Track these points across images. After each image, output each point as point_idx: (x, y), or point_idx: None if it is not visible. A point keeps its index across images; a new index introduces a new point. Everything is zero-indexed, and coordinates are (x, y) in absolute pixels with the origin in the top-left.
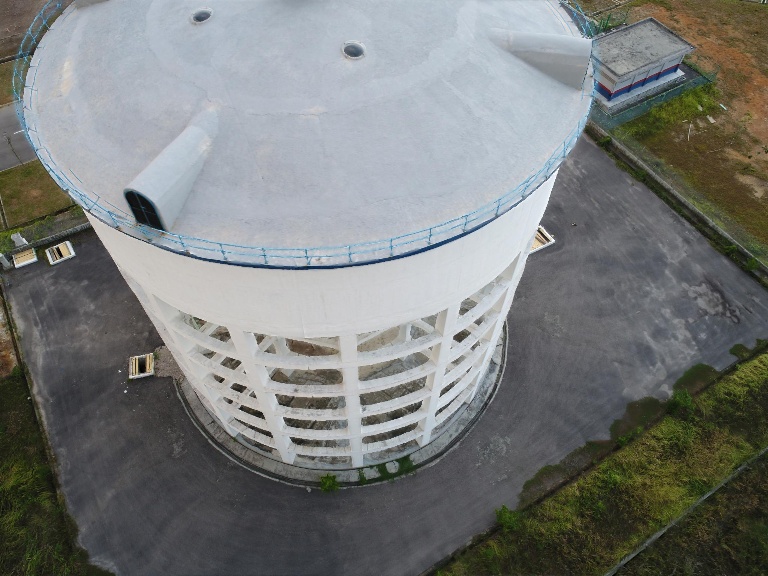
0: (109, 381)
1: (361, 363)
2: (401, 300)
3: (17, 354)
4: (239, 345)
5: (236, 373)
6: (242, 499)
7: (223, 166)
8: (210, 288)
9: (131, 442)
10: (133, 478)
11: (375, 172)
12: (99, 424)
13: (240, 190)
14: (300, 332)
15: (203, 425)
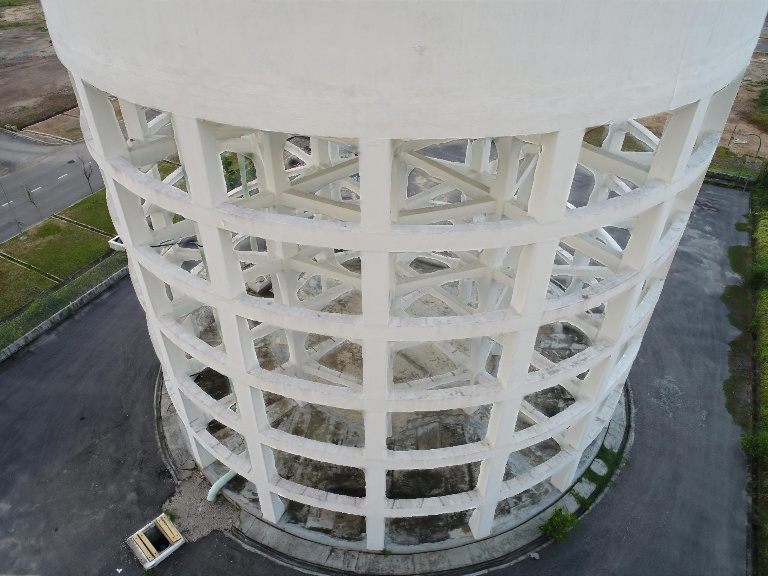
0: None
1: (682, 184)
2: (762, 5)
3: None
4: (556, 186)
5: (487, 314)
6: None
7: None
8: None
9: None
10: None
11: None
12: None
13: None
14: (669, 94)
15: (319, 565)
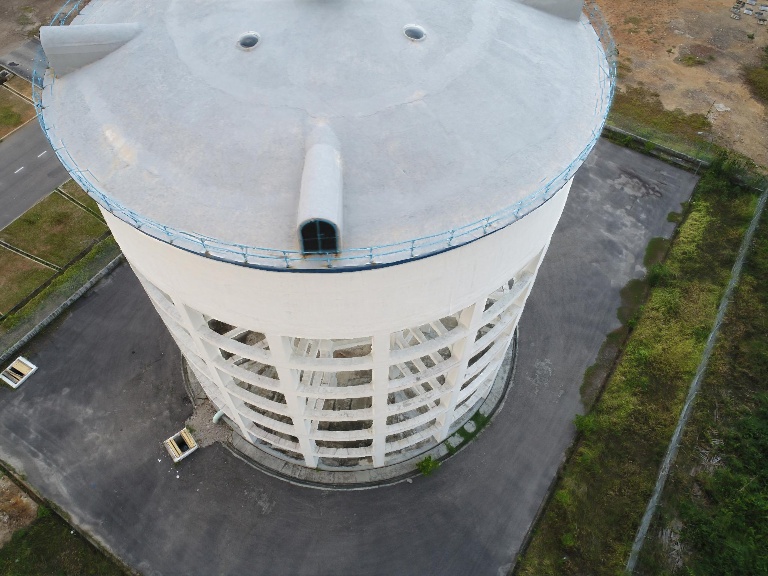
0: (154, 475)
1: (482, 325)
2: (526, 246)
3: (30, 495)
4: (380, 351)
5: (355, 388)
6: (354, 519)
7: (362, 173)
8: (371, 298)
9: (213, 521)
10: (236, 553)
11: (493, 134)
12: (168, 520)
13: (389, 190)
14: (446, 311)
15: (277, 471)
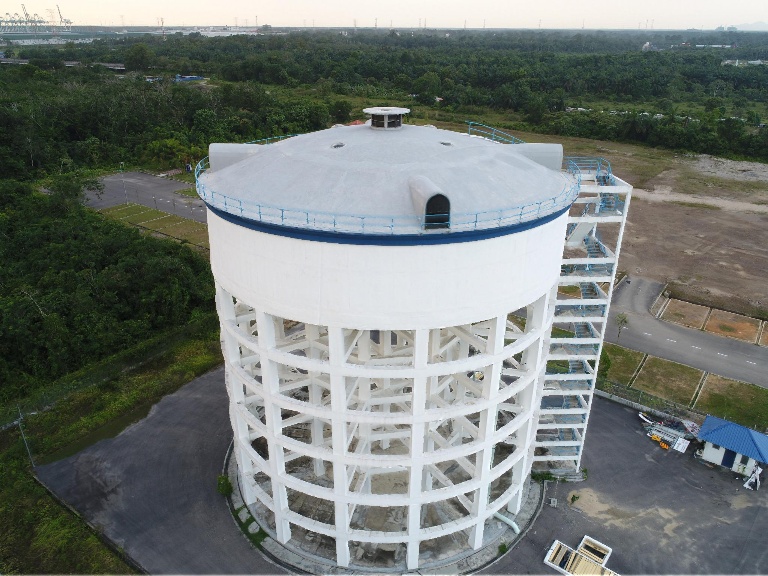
0: None
1: None
2: None
3: None
4: None
5: None
6: (206, 451)
7: None
8: None
9: None
10: (211, 400)
11: None
12: None
13: None
14: None
15: None
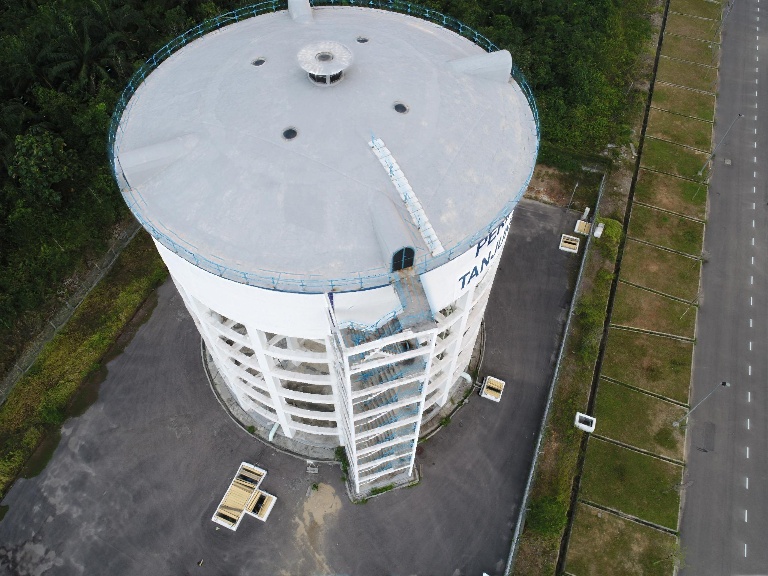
0: None
1: None
2: None
3: None
4: None
5: None
6: None
7: None
8: None
9: None
10: None
11: None
12: None
13: None
14: None
15: None
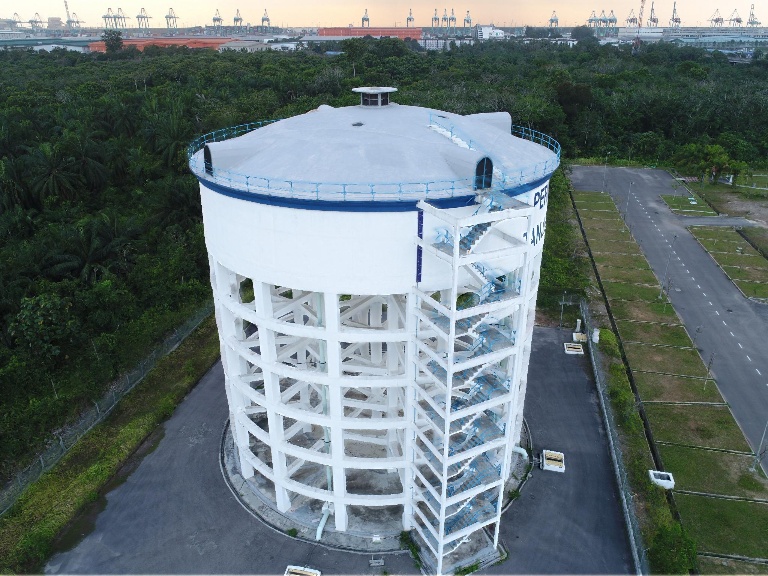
0: None
1: None
2: None
3: None
4: None
5: None
6: None
7: None
8: None
9: None
10: None
11: None
12: None
13: None
14: None
15: None
